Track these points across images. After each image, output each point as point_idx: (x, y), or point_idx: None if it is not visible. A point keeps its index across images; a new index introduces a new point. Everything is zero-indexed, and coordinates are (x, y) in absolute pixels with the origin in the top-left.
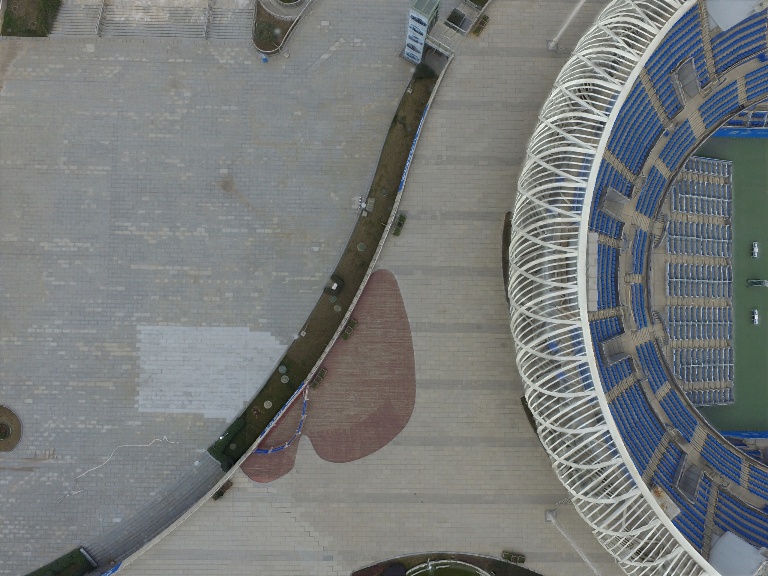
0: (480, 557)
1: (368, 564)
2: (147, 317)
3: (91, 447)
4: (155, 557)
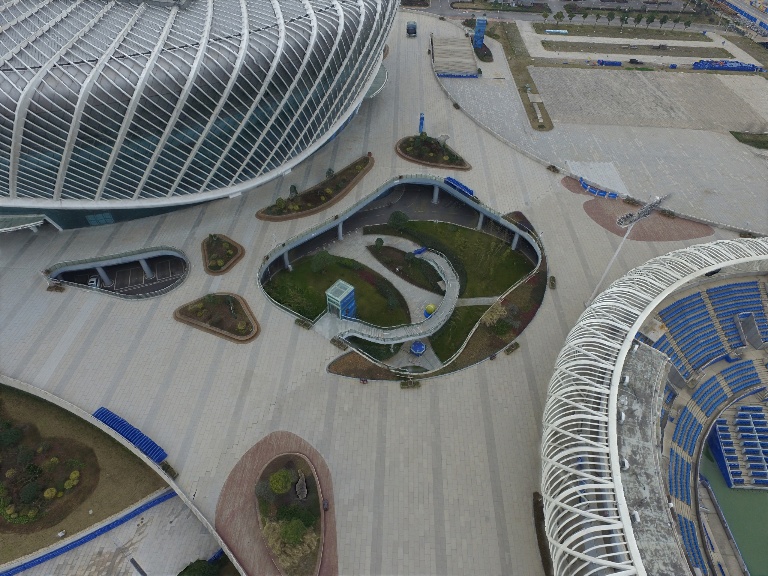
0: (547, 266)
1: (528, 218)
2: (618, 165)
3: (543, 148)
4: (511, 151)
